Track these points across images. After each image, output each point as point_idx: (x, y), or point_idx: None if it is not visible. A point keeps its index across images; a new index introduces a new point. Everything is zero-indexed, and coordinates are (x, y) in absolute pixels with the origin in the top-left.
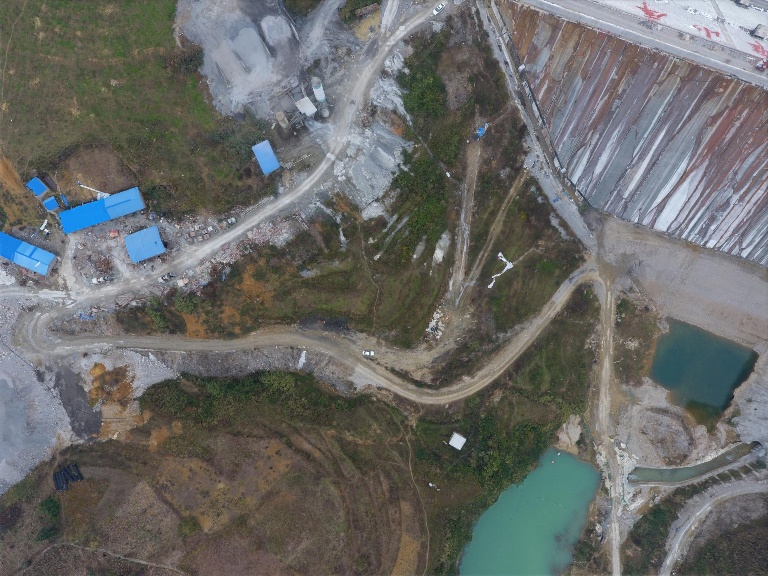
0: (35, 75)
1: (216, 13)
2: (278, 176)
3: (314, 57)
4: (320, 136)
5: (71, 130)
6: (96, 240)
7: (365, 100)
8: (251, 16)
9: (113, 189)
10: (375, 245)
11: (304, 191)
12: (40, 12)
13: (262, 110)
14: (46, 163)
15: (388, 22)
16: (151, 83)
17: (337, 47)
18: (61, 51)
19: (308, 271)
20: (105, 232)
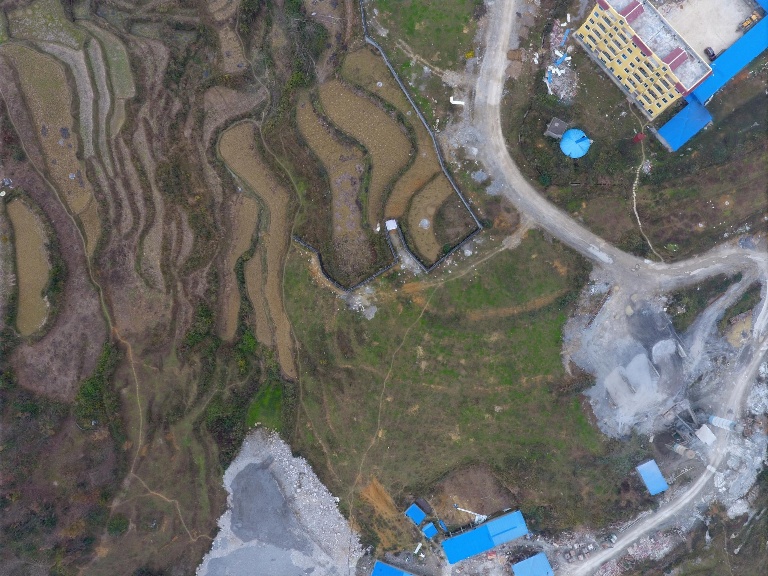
0: (414, 402)
1: (607, 340)
2: (660, 492)
3: (698, 373)
4: (699, 448)
5: (449, 454)
6: (472, 562)
7: (742, 409)
8: (643, 342)
9: (491, 511)
10: (738, 541)
11: (684, 504)
12: (422, 341)
13: (645, 428)
14: (425, 490)
15: (761, 327)
16: (535, 407)
17: (716, 359)
18: (445, 380)
19: (671, 570)
20: (482, 554)
